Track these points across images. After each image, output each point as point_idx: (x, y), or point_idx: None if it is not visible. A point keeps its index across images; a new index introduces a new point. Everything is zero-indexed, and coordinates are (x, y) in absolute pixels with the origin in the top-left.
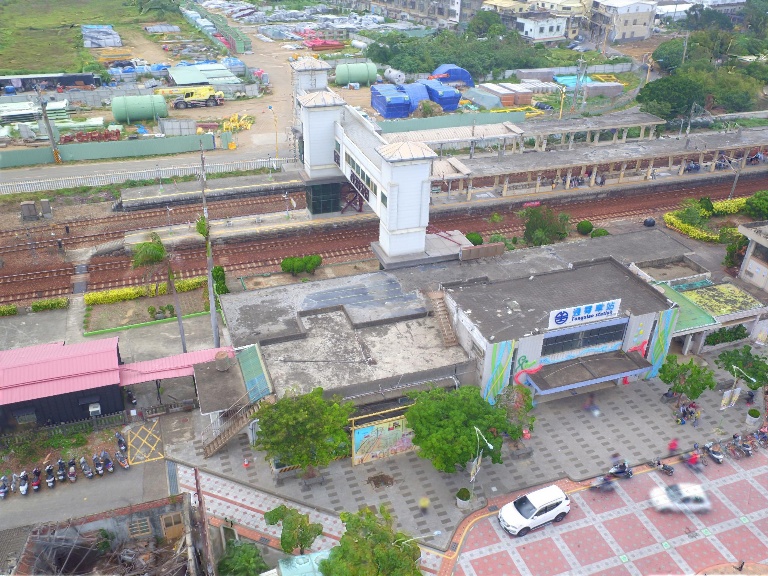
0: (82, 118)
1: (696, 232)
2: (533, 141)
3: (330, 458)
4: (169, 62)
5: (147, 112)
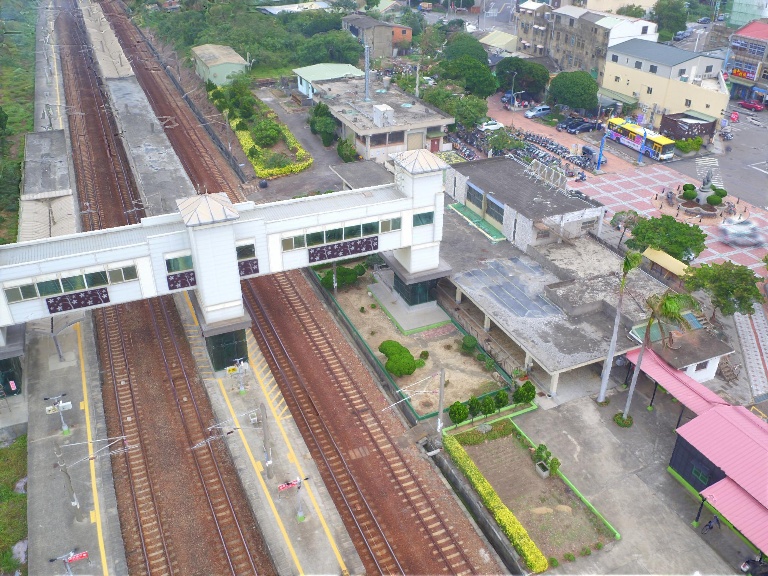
0: None
1: (299, 166)
2: (1, 216)
3: None
4: None
5: None
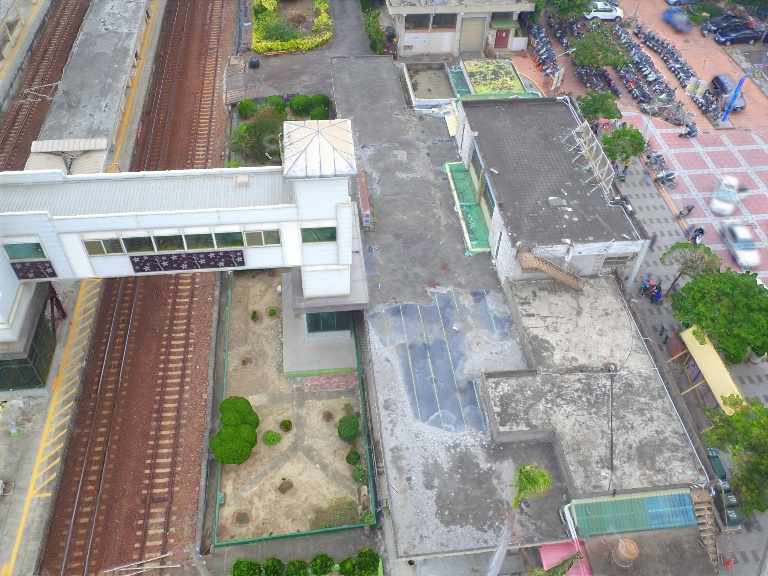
0: None
1: (309, 42)
2: None
3: None
4: None
5: None
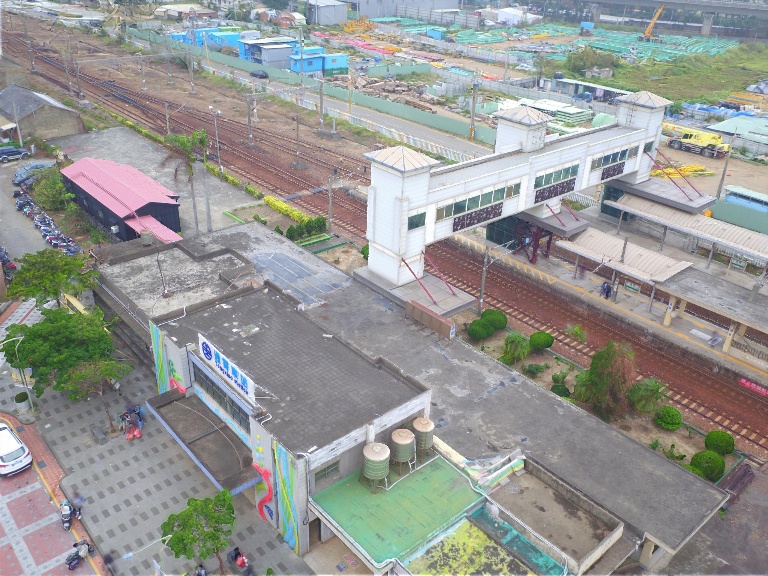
0: (571, 124)
1: None
2: None
3: (12, 294)
4: (760, 113)
5: None
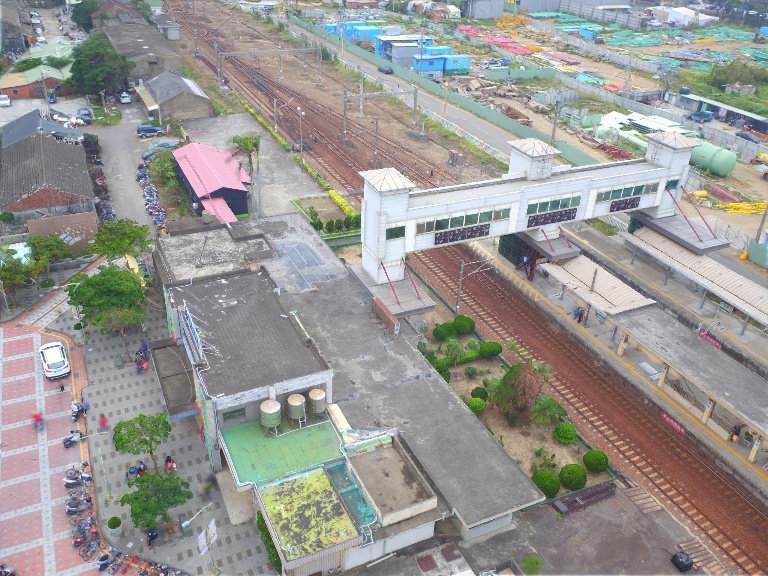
0: None
1: None
2: None
3: (91, 250)
4: None
5: (705, 162)
